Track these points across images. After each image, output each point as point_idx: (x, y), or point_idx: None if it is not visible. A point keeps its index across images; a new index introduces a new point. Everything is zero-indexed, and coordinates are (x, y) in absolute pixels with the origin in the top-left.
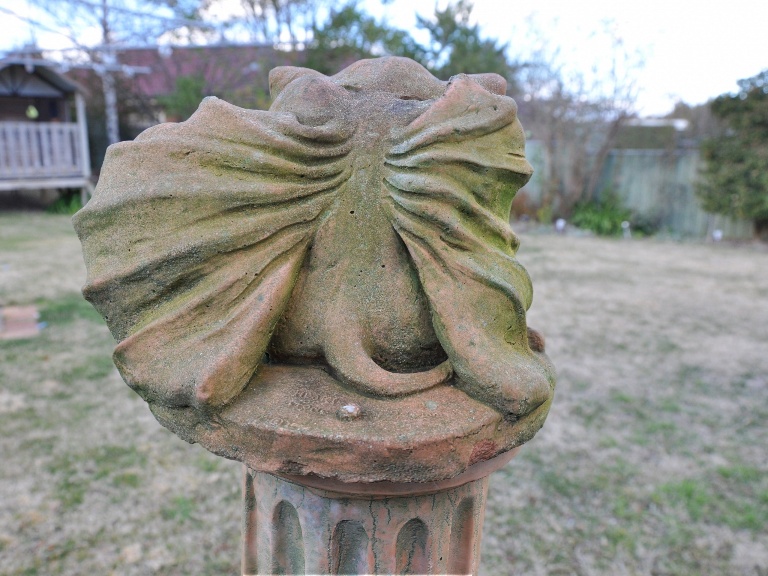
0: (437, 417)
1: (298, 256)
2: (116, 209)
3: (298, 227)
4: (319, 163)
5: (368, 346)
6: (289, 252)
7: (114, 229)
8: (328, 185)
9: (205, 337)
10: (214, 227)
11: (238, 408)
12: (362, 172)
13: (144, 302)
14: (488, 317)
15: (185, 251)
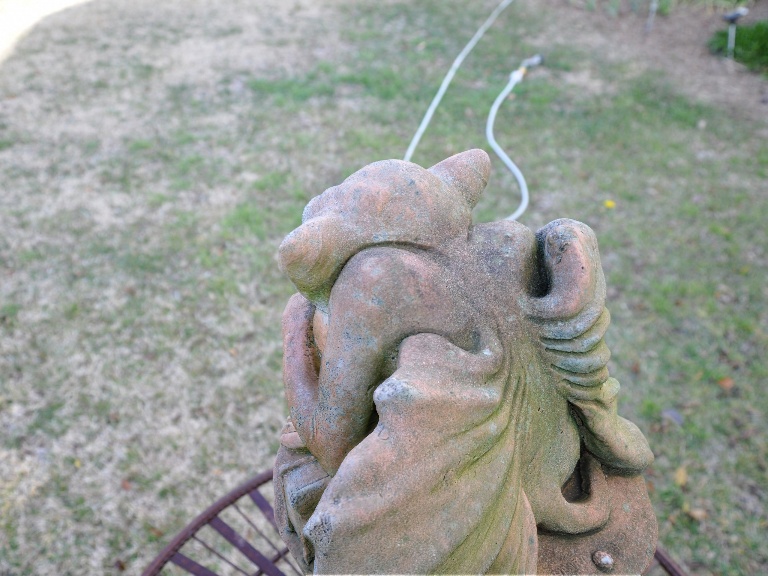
0: (638, 516)
1: None
2: None
3: None
4: None
5: None
6: None
7: None
8: None
9: None
10: (498, 526)
11: None
12: (531, 368)
13: None
14: None
15: None
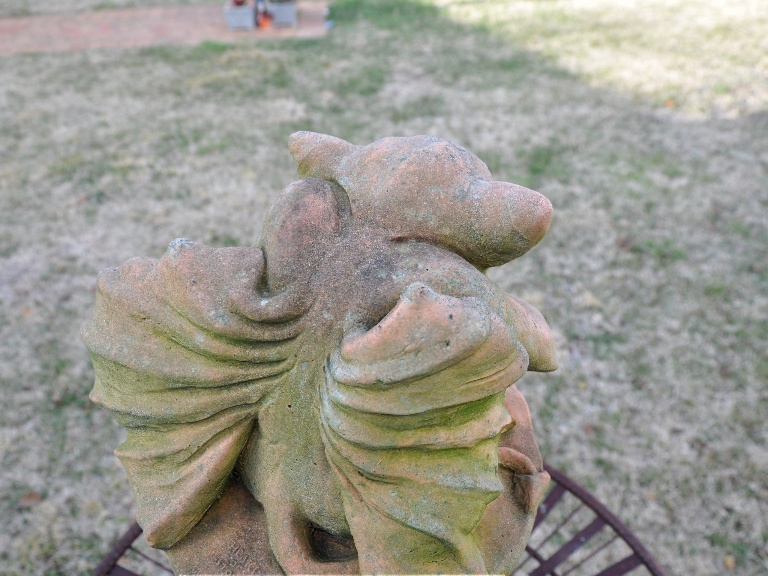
0: None
1: (243, 428)
2: None
3: (241, 407)
4: (265, 344)
5: (301, 520)
6: (233, 426)
7: None
8: (270, 373)
9: (160, 485)
10: (162, 401)
11: (181, 551)
12: (304, 366)
13: (129, 426)
14: (403, 549)
15: (140, 415)
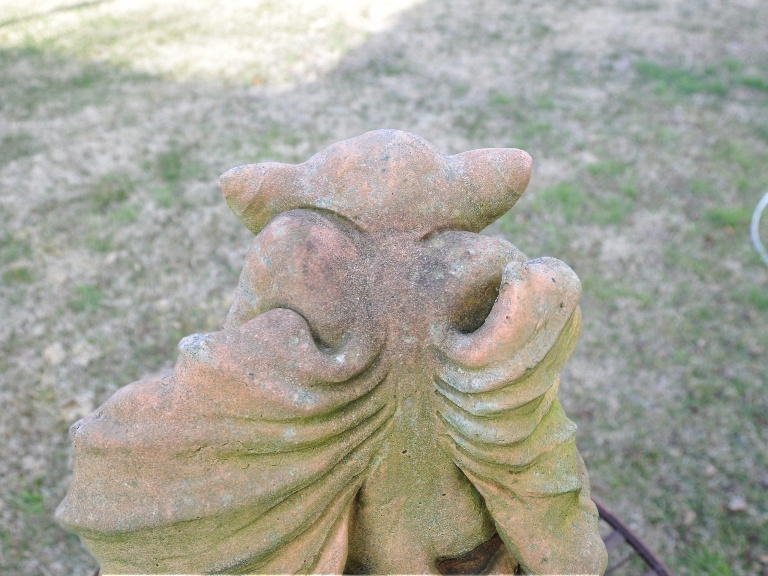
0: None
1: (349, 507)
2: (127, 533)
3: (347, 484)
4: (356, 403)
5: (433, 562)
6: None
7: (129, 546)
8: (373, 430)
9: None
10: (258, 532)
11: None
12: (409, 402)
13: None
14: (554, 520)
15: (231, 566)
